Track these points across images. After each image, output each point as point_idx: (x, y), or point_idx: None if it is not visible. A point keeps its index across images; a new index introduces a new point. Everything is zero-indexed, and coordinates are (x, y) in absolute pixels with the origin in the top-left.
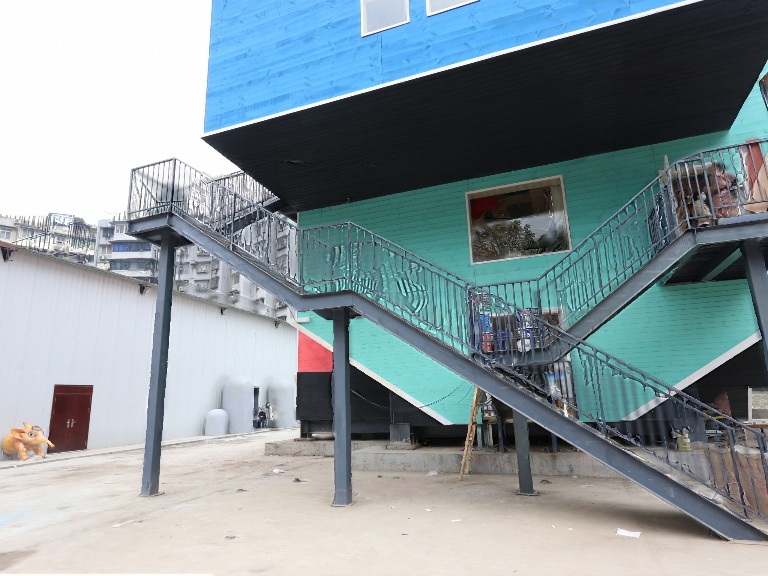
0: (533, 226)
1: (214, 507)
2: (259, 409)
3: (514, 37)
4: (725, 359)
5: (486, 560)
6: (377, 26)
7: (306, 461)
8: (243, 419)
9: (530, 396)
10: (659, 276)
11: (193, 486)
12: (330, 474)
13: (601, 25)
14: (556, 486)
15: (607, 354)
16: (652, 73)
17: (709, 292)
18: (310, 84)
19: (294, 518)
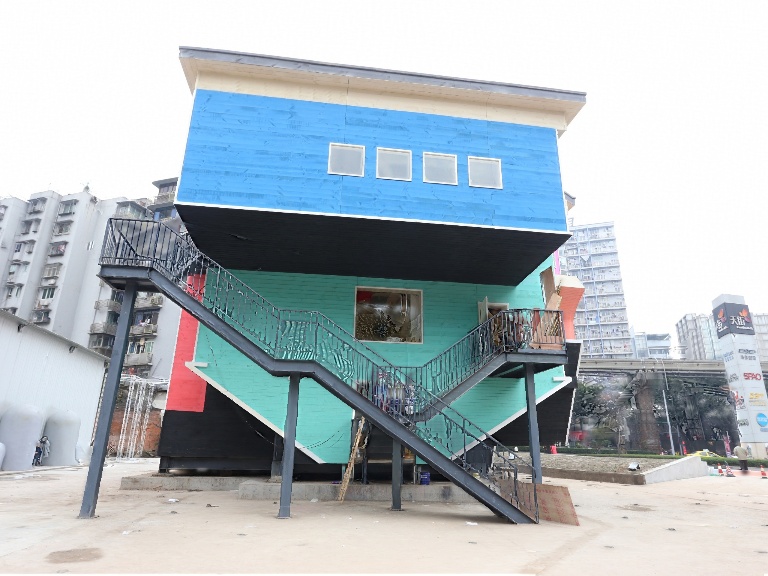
0: (393, 318)
1: (180, 522)
2: None
3: (430, 213)
4: (501, 427)
5: (419, 535)
6: (340, 170)
7: (179, 494)
8: (25, 454)
9: None
10: None
11: (113, 511)
12: (227, 502)
13: (478, 225)
14: (408, 506)
15: None
16: (492, 252)
17: (497, 384)
18: (282, 193)
19: (265, 525)
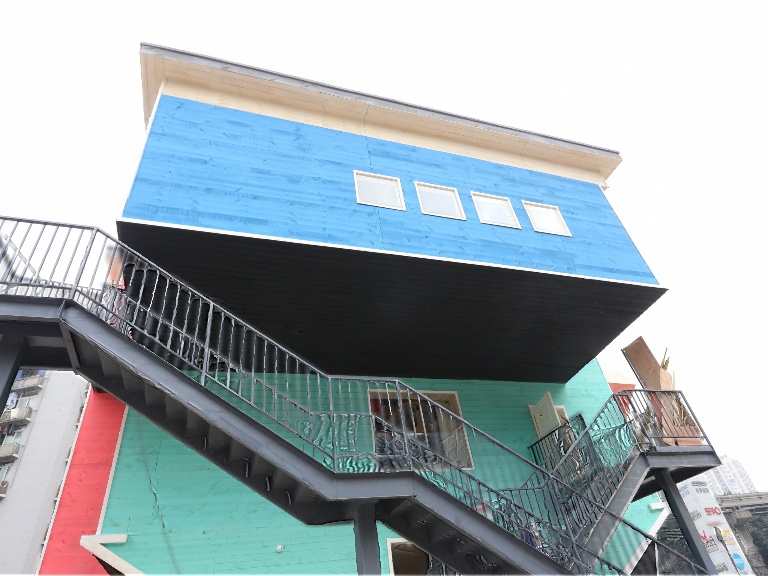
0: None
1: None
2: None
3: (500, 258)
4: None
5: None
6: (372, 201)
7: None
8: None
9: None
10: None
11: None
12: None
13: (564, 274)
14: None
15: None
16: (562, 323)
17: None
18: (297, 221)
19: None
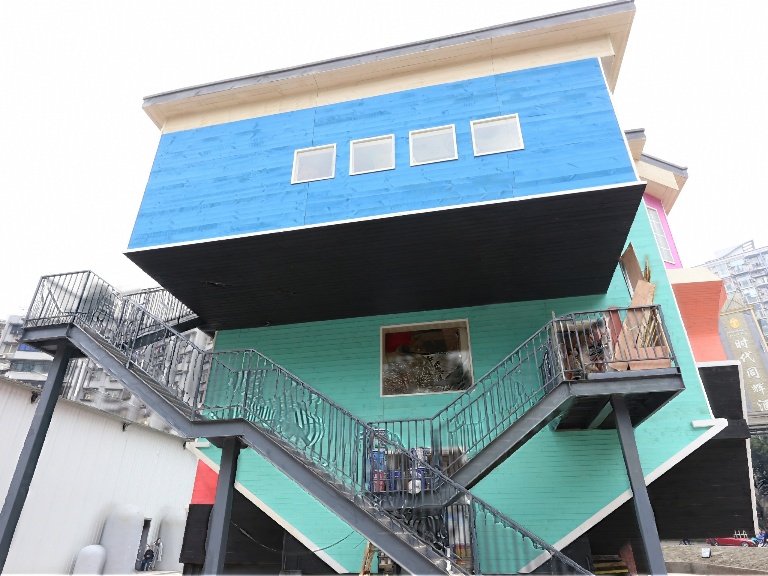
0: (443, 363)
1: None
2: (147, 546)
3: (420, 202)
4: (612, 509)
5: None
6: (306, 177)
7: None
8: (123, 559)
9: (407, 544)
10: (544, 422)
11: None
12: None
13: (490, 202)
14: None
15: (482, 501)
16: (536, 243)
17: (595, 440)
18: (238, 217)
19: None
